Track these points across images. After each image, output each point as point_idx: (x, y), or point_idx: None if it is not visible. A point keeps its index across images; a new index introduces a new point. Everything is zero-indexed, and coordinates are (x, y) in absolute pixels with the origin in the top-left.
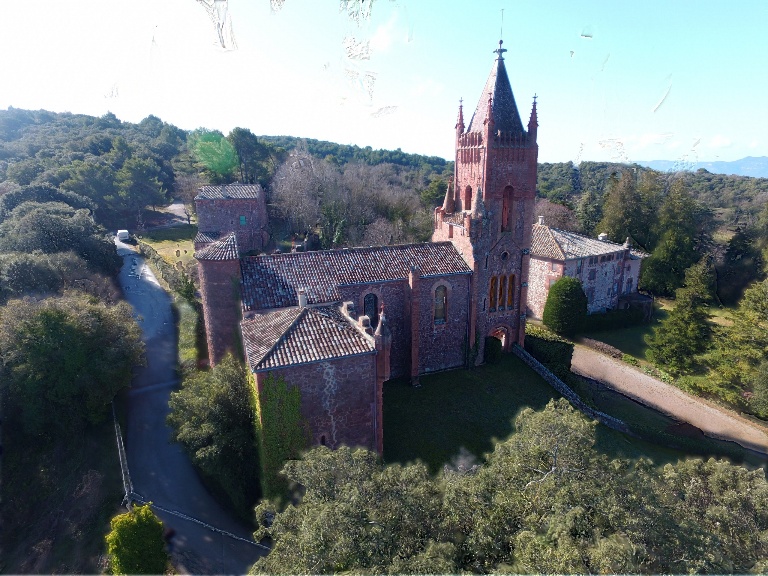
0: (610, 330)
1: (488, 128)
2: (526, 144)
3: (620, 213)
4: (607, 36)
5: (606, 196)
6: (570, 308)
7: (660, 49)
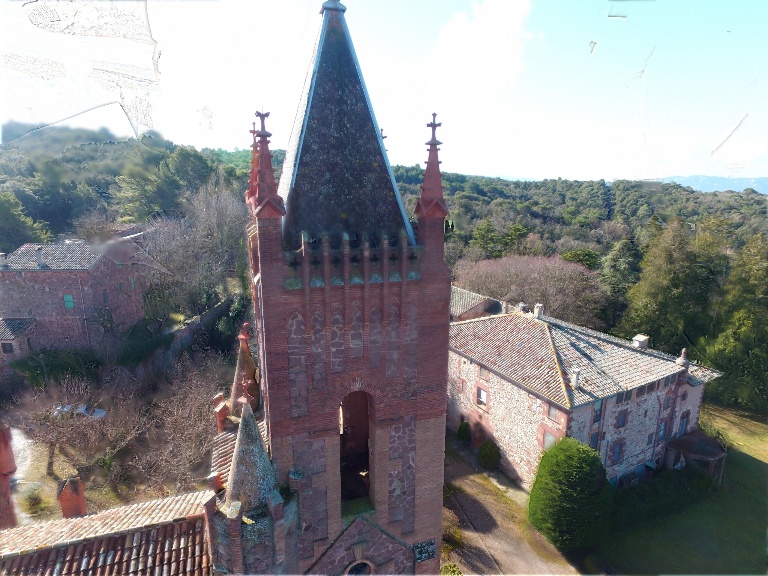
0: (652, 520)
1: (258, 229)
2: (408, 269)
3: (665, 279)
4: (652, 14)
5: (644, 248)
6: (577, 510)
7: (741, 37)
